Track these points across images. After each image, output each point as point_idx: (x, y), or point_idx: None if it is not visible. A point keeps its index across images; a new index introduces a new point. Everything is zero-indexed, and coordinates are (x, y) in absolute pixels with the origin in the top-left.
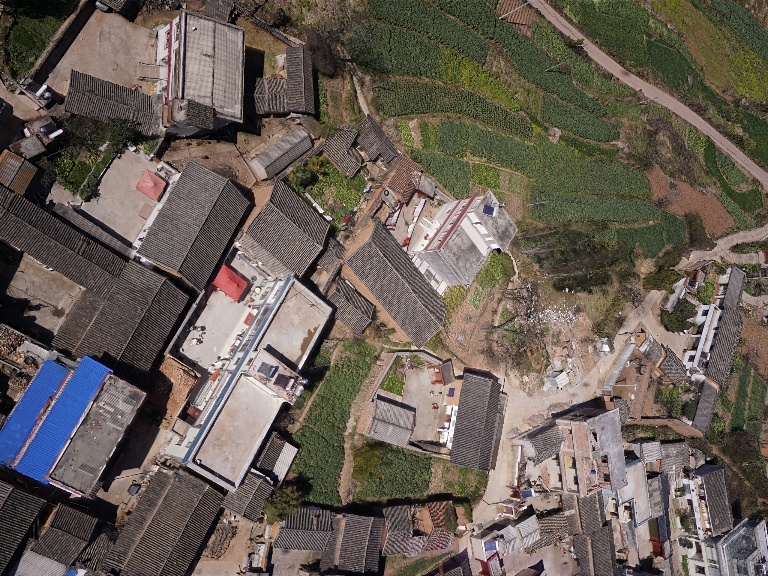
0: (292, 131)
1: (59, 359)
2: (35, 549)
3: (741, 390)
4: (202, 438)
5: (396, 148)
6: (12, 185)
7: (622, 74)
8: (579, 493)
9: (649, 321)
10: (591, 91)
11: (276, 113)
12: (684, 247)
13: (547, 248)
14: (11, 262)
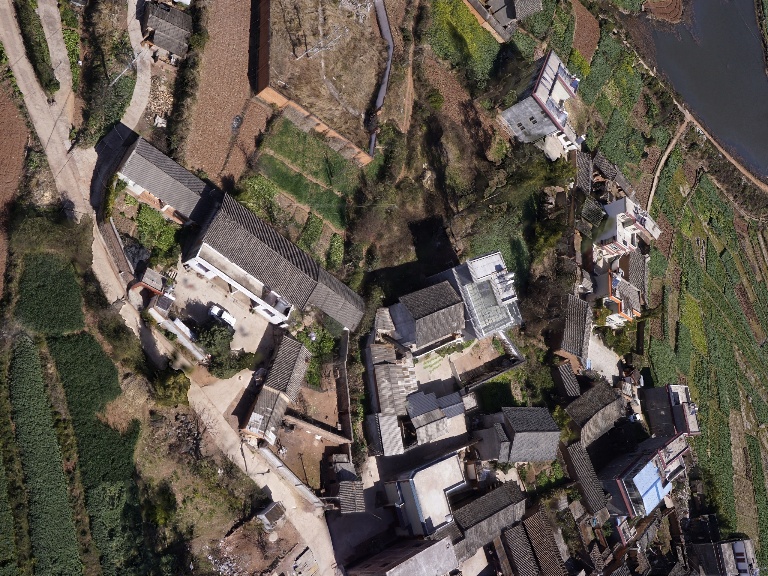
0: None
1: None
2: None
3: (296, 192)
4: None
5: None
6: None
7: None
8: None
9: (220, 396)
10: None
11: None
12: None
13: None
14: None
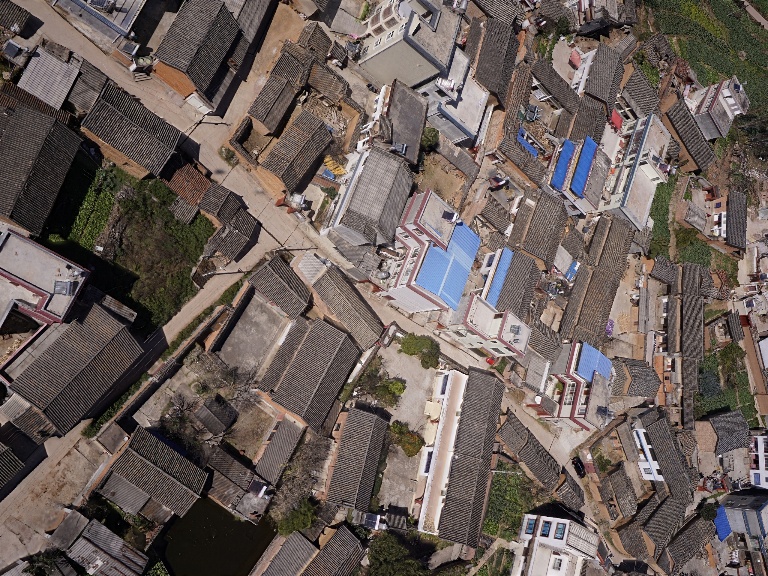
0: (627, 35)
1: None
2: (563, 244)
3: None
4: (629, 194)
5: None
6: None
7: (764, 23)
8: None
9: None
10: None
11: (615, 25)
12: None
13: (761, 120)
14: None
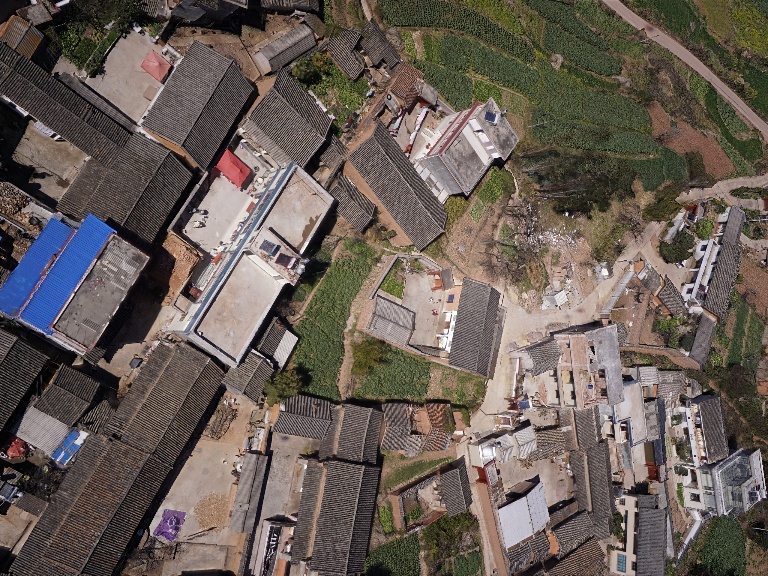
0: None
1: (64, 220)
2: (38, 406)
3: (738, 327)
4: (204, 310)
5: (399, 56)
6: (19, 49)
7: (625, 13)
8: (576, 406)
9: (648, 252)
10: (594, 26)
11: (280, 10)
12: (684, 182)
13: (548, 164)
14: (17, 128)
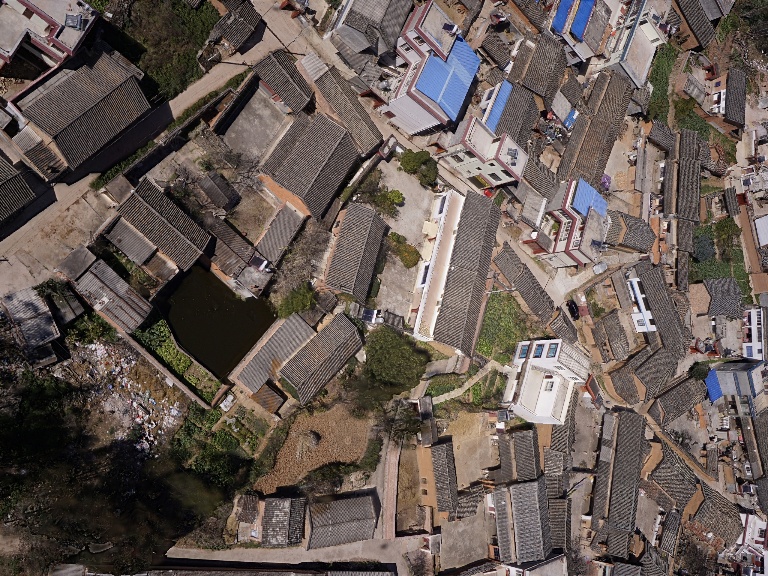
0: None
1: None
2: (562, 90)
3: None
4: None
5: None
6: None
7: None
8: None
9: None
10: None
11: None
12: None
13: (763, 6)
14: None
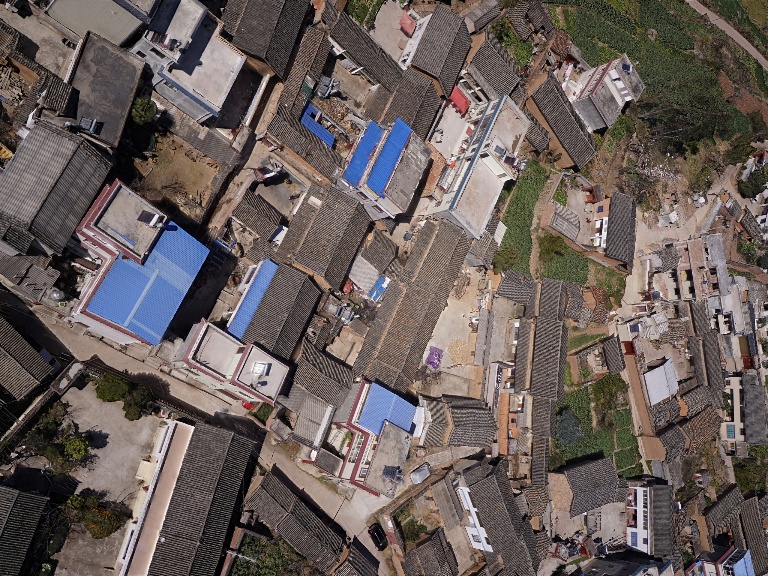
0: None
1: None
2: (364, 255)
3: None
4: (461, 194)
5: None
6: (336, 7)
7: (691, 1)
8: (695, 297)
9: (729, 188)
10: None
11: None
12: (751, 134)
13: (661, 109)
14: (330, 65)
